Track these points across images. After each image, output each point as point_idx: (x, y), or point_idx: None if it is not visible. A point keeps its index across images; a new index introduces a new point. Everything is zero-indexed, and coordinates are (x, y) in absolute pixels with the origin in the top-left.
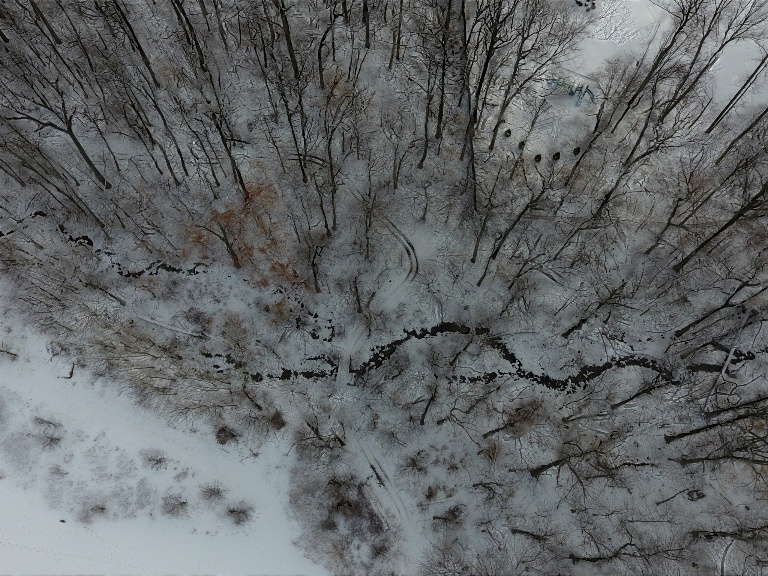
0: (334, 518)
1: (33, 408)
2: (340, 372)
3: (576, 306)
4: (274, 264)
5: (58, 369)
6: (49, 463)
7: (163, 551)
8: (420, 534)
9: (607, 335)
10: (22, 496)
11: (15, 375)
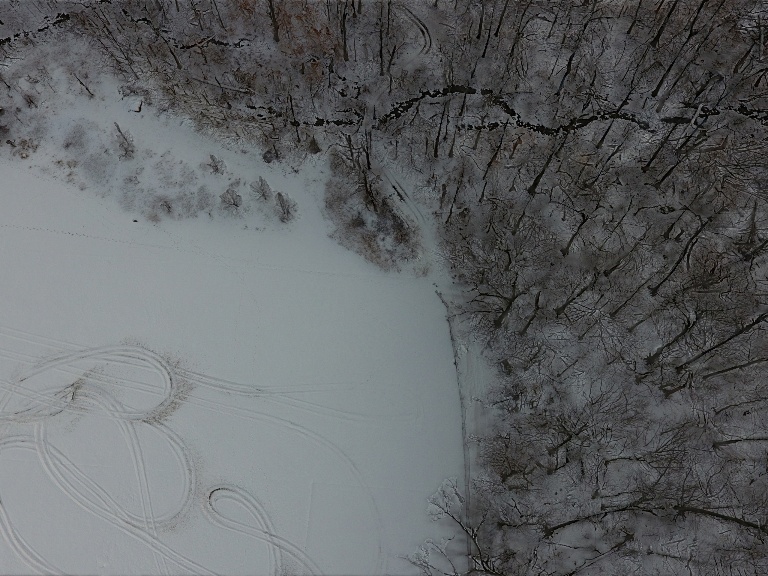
0: (363, 216)
1: (109, 134)
2: (366, 119)
3: None
4: (309, 30)
5: (129, 104)
6: (123, 175)
7: (220, 242)
8: (435, 233)
9: (593, 96)
10: (101, 203)
11: (93, 110)
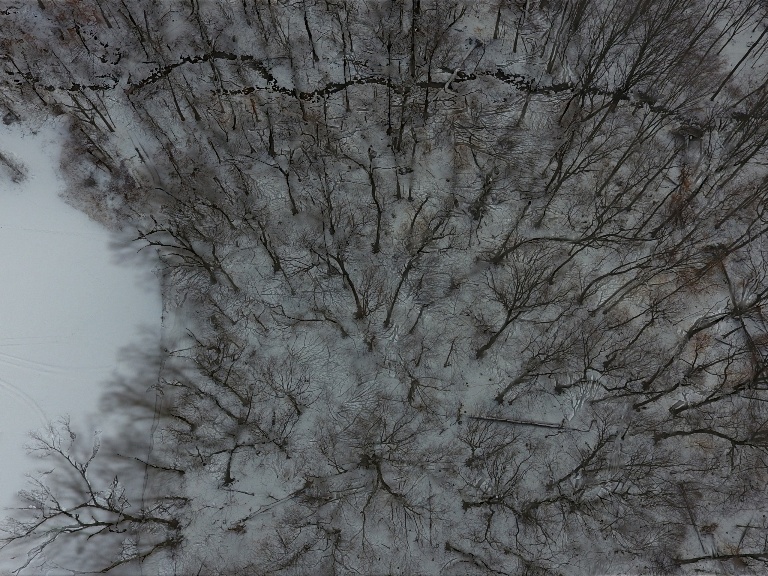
0: (94, 176)
1: None
2: (120, 83)
3: (326, 37)
4: None
5: None
6: None
7: None
8: None
9: (353, 61)
10: None
11: None
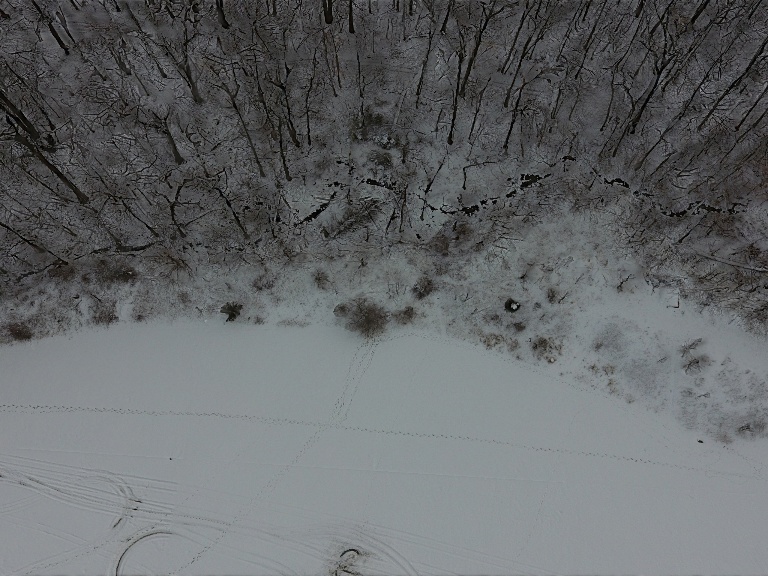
0: None
1: (652, 336)
2: None
3: None
4: None
5: (666, 299)
6: (680, 387)
7: None
8: None
9: None
10: (655, 419)
11: (625, 305)
